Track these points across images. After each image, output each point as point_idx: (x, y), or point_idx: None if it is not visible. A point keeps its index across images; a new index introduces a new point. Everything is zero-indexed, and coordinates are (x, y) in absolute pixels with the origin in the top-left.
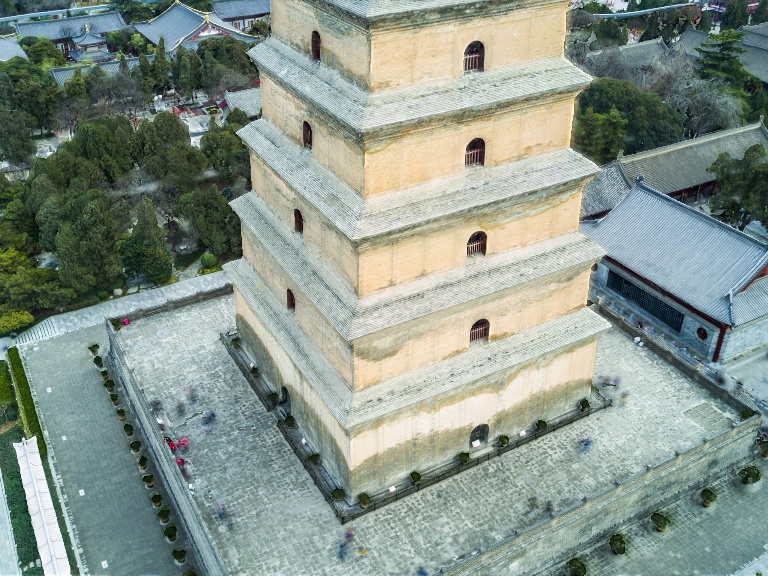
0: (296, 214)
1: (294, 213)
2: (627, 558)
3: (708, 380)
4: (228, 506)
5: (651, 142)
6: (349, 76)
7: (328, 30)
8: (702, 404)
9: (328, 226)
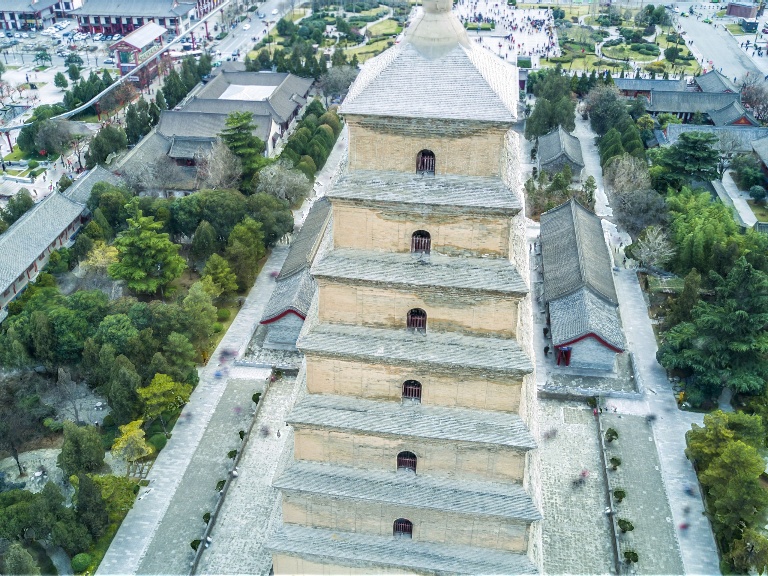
0: (398, 456)
1: (397, 456)
2: None
3: (554, 393)
4: None
5: (281, 232)
6: (480, 332)
7: (443, 305)
8: (564, 410)
9: (472, 449)
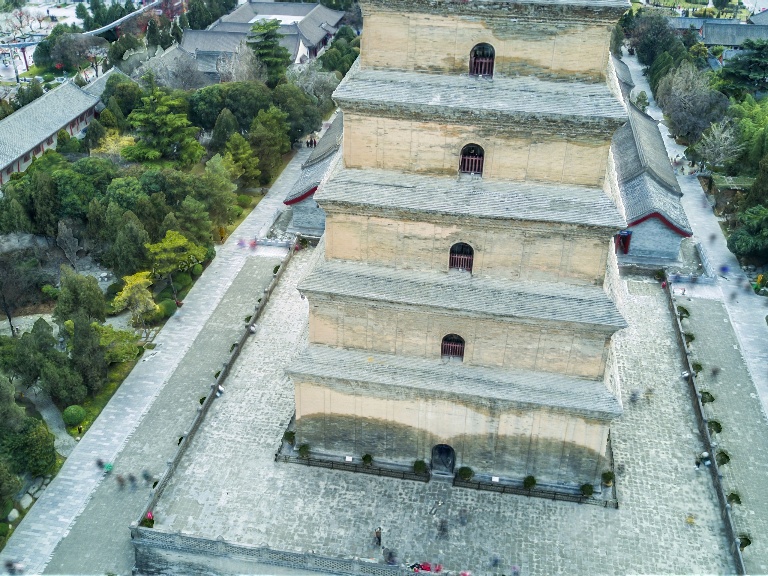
0: (451, 250)
1: (450, 250)
2: (709, 404)
3: None
4: (536, 572)
5: (308, 127)
6: (561, 75)
7: (516, 36)
8: (628, 283)
9: (543, 236)
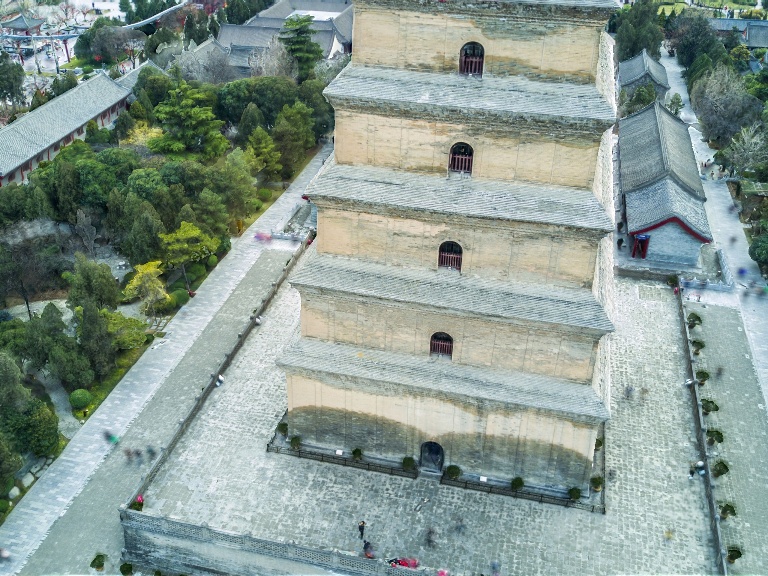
0: (440, 248)
1: (439, 248)
2: (714, 413)
3: (628, 269)
4: (515, 573)
5: None
6: (550, 76)
7: (505, 36)
8: (639, 288)
9: (532, 237)
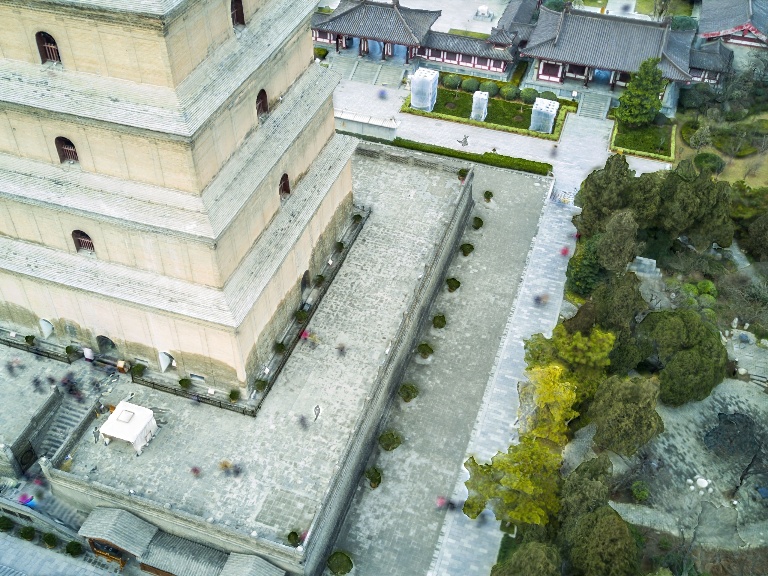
0: None
1: None
2: None
3: None
4: None
5: None
6: None
7: None
8: None
9: None
